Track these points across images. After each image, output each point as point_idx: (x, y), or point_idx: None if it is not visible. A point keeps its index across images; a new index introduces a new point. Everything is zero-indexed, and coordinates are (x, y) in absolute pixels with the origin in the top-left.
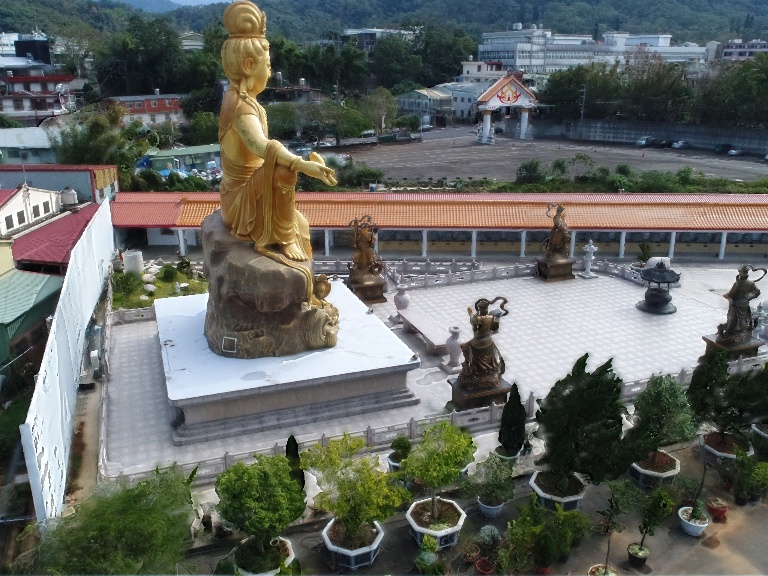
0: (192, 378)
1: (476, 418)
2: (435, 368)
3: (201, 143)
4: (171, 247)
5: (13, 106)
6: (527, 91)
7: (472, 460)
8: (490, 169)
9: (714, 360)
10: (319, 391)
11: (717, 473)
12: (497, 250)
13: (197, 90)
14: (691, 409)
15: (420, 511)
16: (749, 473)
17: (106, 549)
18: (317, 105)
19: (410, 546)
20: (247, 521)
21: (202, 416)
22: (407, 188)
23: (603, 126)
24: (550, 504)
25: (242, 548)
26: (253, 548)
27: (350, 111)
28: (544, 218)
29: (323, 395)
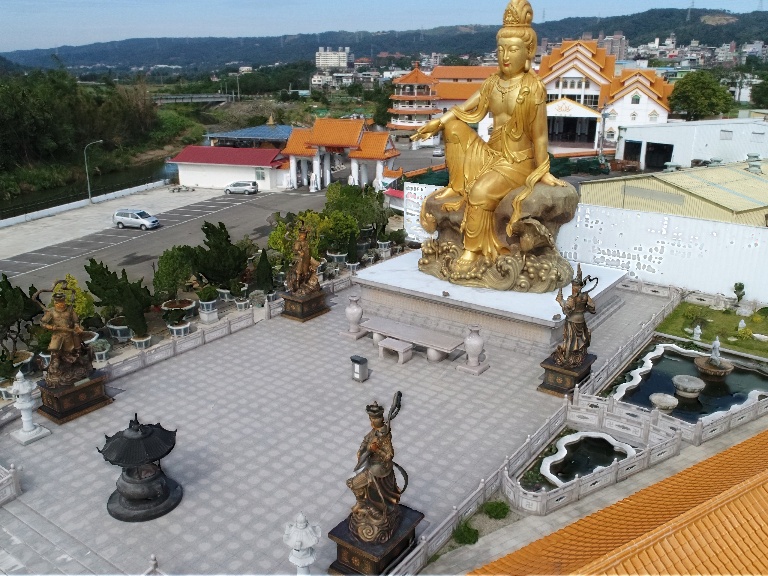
0: None
1: None
2: None
3: None
4: None
5: None
6: None
7: None
8: None
9: None
10: None
11: None
12: None
13: None
14: None
15: None
16: None
17: None
18: None
19: None
20: None
21: None
22: None
23: None
24: None
25: None
26: None
27: None
28: None
29: None
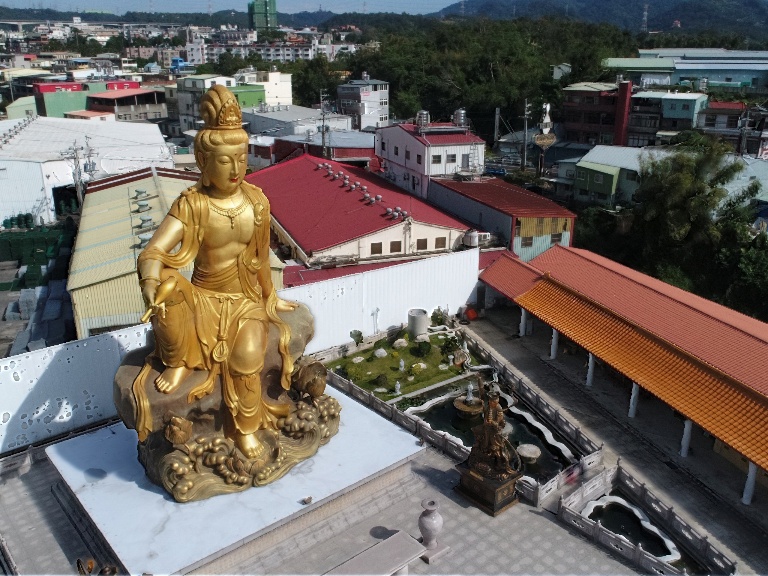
0: (92, 443)
1: None
2: None
3: None
4: (539, 321)
5: (726, 122)
6: None
7: None
8: None
9: None
10: None
11: None
12: None
13: None
14: None
15: None
16: None
17: None
18: None
19: None
20: None
21: None
22: None
23: None
24: None
25: None
26: None
27: None
28: None
29: None
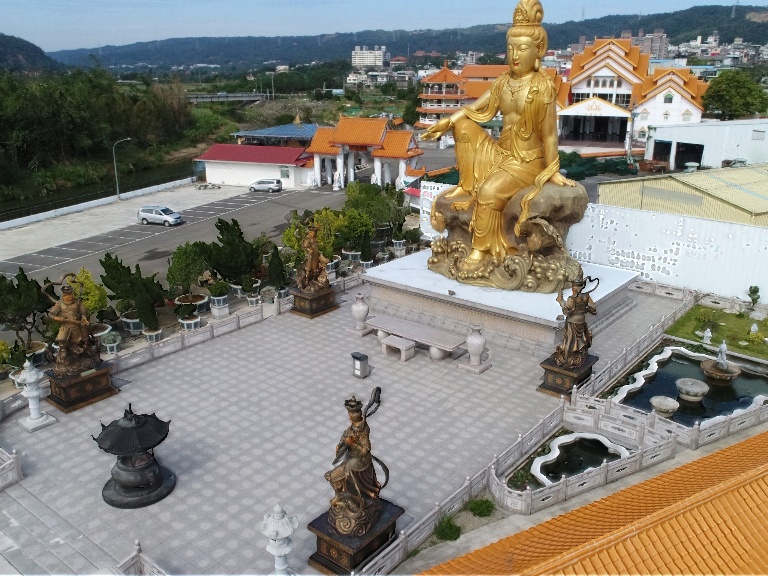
0: None
1: None
2: None
3: None
4: None
5: None
6: None
7: None
8: None
9: None
10: None
11: None
12: None
13: None
14: None
15: None
16: None
17: None
18: None
19: None
20: None
21: None
22: None
23: None
24: None
25: None
26: None
27: None
28: None
29: None
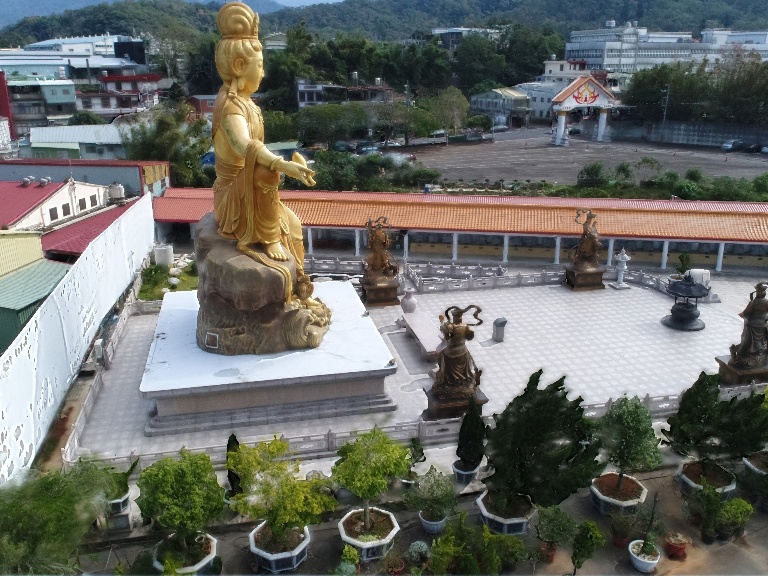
0: (169, 371)
1: (446, 429)
2: (425, 375)
3: (270, 141)
4: None
5: (101, 104)
6: (606, 91)
7: (404, 472)
8: (554, 172)
9: (702, 384)
10: (292, 391)
11: (686, 506)
12: (532, 256)
13: (273, 89)
14: (669, 435)
15: (354, 520)
16: (716, 509)
17: (2, 532)
18: (385, 105)
19: (339, 555)
20: (159, 516)
21: (174, 409)
22: (463, 189)
23: (687, 128)
24: (493, 524)
25: (166, 542)
26: (176, 543)
27: (418, 111)
28: (580, 224)
29: (296, 395)
